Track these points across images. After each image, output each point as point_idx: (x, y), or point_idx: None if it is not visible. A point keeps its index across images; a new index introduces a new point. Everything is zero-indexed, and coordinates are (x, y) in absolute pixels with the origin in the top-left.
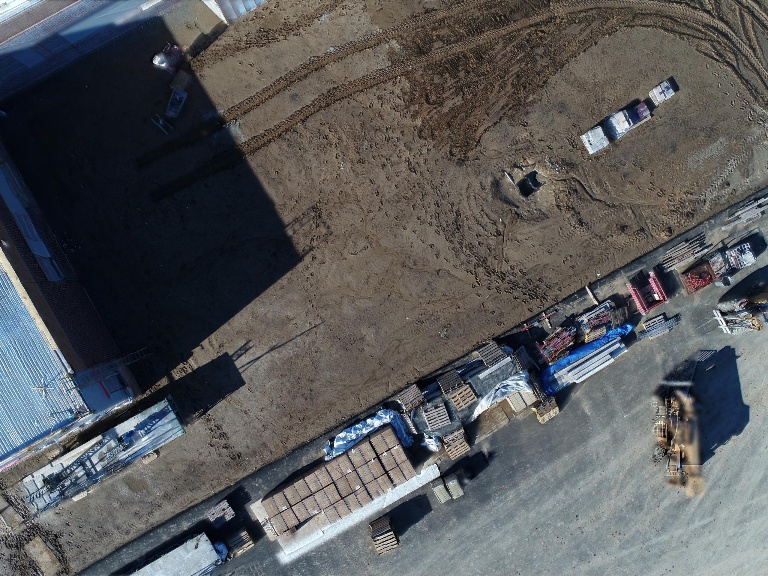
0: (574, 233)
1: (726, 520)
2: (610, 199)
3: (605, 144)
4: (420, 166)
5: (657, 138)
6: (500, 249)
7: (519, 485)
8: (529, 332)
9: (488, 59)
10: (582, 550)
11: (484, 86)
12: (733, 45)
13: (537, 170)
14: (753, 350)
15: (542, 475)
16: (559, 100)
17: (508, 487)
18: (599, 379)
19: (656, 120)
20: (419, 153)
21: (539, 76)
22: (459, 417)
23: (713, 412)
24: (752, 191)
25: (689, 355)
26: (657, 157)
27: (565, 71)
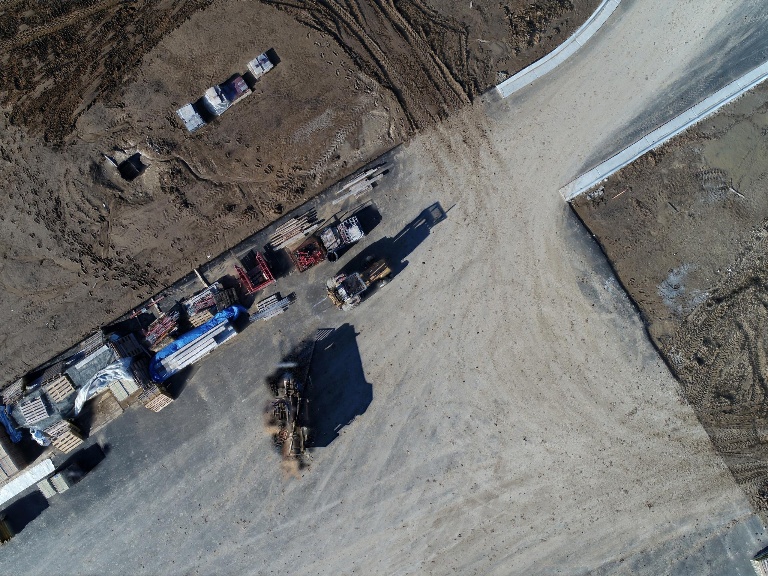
0: (180, 215)
1: (354, 502)
2: (217, 178)
3: (199, 121)
4: (14, 154)
5: (261, 113)
6: (105, 235)
7: (138, 476)
8: (138, 319)
9: (78, 40)
10: (207, 539)
11: (76, 68)
12: (333, 12)
13: (140, 152)
14: (373, 326)
15: (161, 465)
16: (156, 79)
17: (126, 479)
18: (214, 364)
19: (258, 94)
20: (13, 140)
21: (133, 55)
22: (58, 409)
23: (334, 392)
24: (364, 162)
25: (306, 335)
26: (262, 132)
27: (160, 48)
